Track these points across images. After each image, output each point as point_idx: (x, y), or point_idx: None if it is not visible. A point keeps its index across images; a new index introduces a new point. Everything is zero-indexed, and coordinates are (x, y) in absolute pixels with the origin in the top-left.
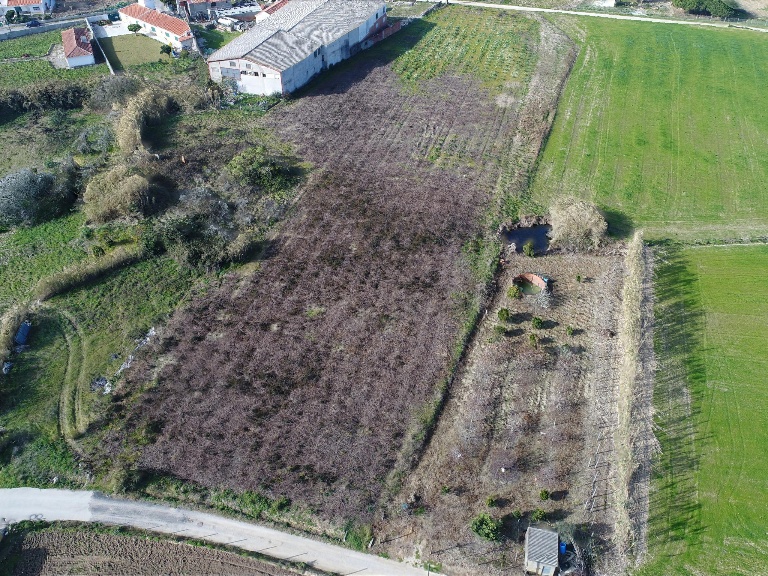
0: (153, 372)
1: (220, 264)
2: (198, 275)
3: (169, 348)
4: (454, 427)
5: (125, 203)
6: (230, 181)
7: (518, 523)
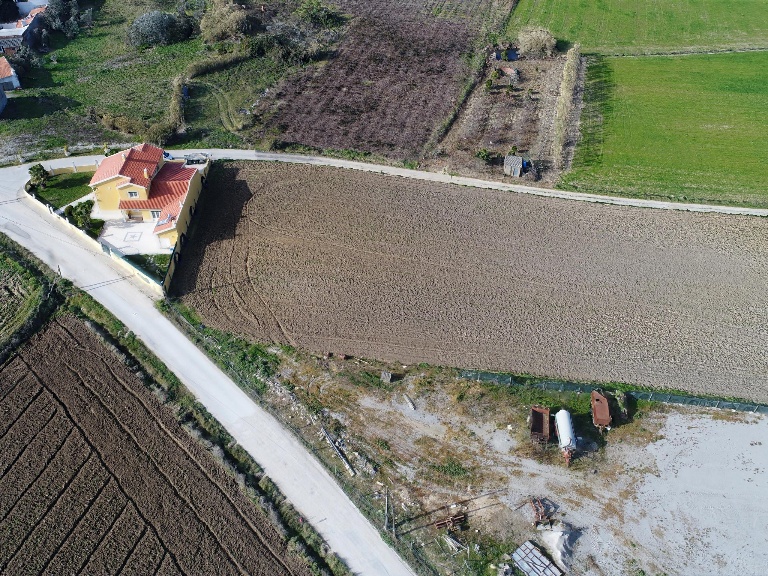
0: (274, 107)
1: (303, 60)
2: (289, 66)
3: (281, 97)
4: (461, 129)
5: (232, 28)
6: (298, 20)
7: (500, 158)
